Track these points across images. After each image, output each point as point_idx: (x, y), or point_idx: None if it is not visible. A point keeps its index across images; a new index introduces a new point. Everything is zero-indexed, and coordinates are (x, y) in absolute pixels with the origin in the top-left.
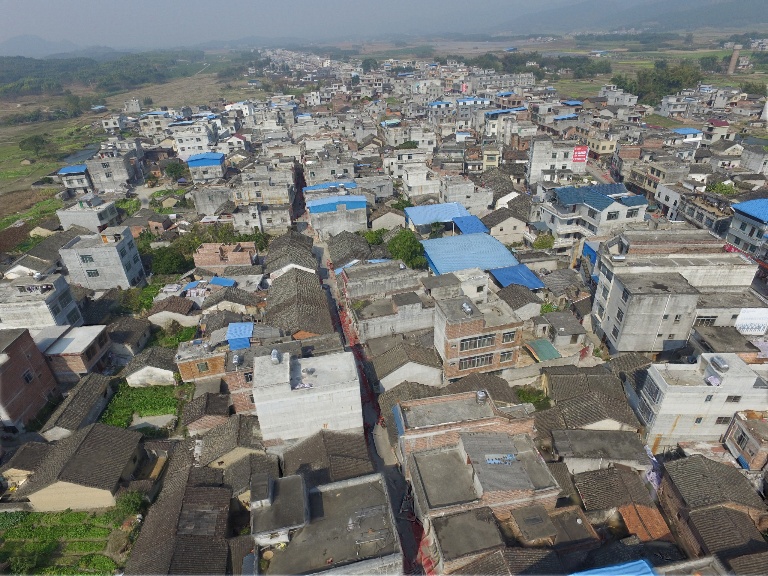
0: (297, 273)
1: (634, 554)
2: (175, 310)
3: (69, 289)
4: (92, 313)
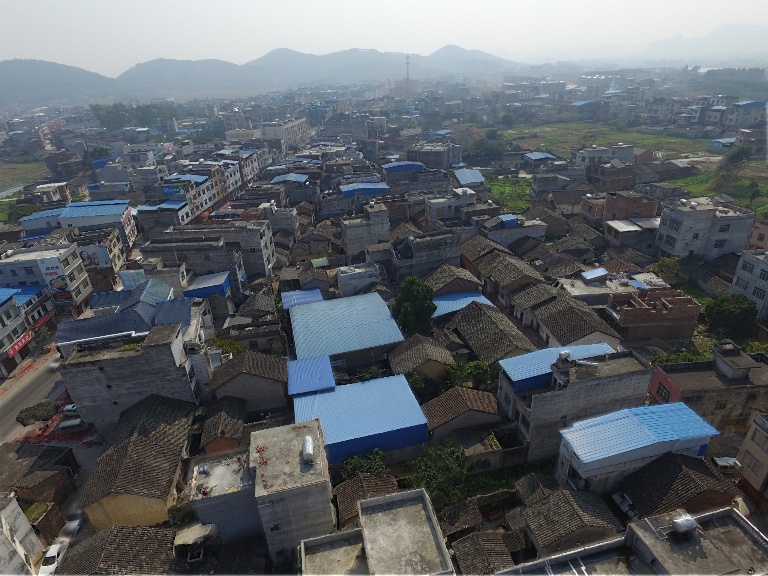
0: (519, 271)
1: None
2: (609, 263)
3: (681, 224)
4: (694, 268)
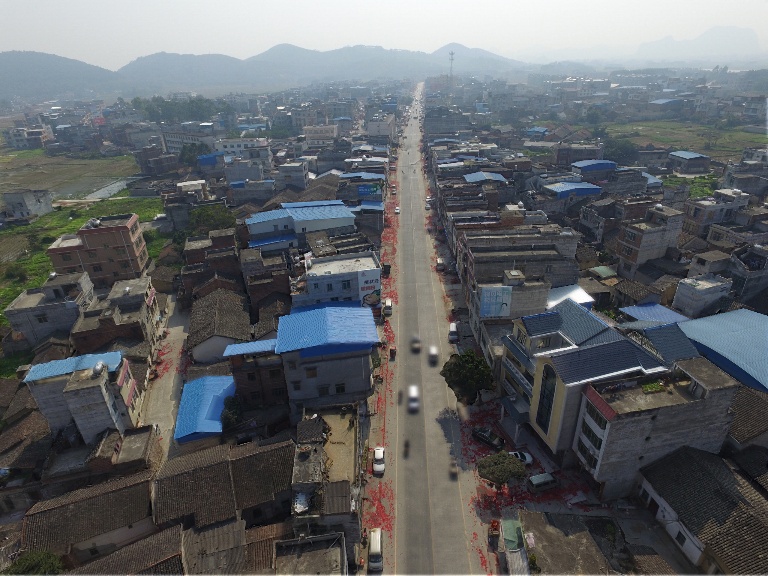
0: None
1: (551, 221)
2: None
3: None
4: None
